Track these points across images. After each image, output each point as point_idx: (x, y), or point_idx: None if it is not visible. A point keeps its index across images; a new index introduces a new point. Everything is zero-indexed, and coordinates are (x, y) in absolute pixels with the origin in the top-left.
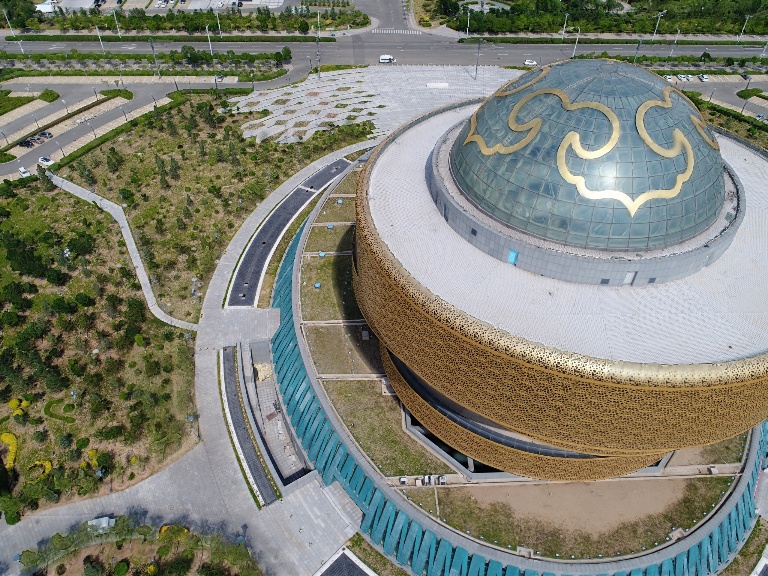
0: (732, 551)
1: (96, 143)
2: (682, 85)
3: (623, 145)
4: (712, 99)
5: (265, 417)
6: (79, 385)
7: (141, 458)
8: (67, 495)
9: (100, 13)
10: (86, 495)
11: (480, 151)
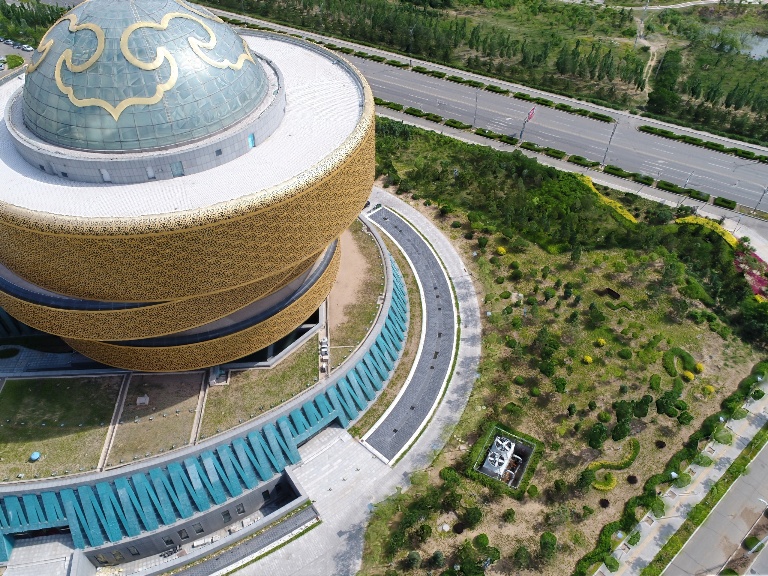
0: None
1: None
2: None
3: (210, 28)
4: None
5: None
6: None
7: None
8: None
9: None
10: None
11: (147, 105)
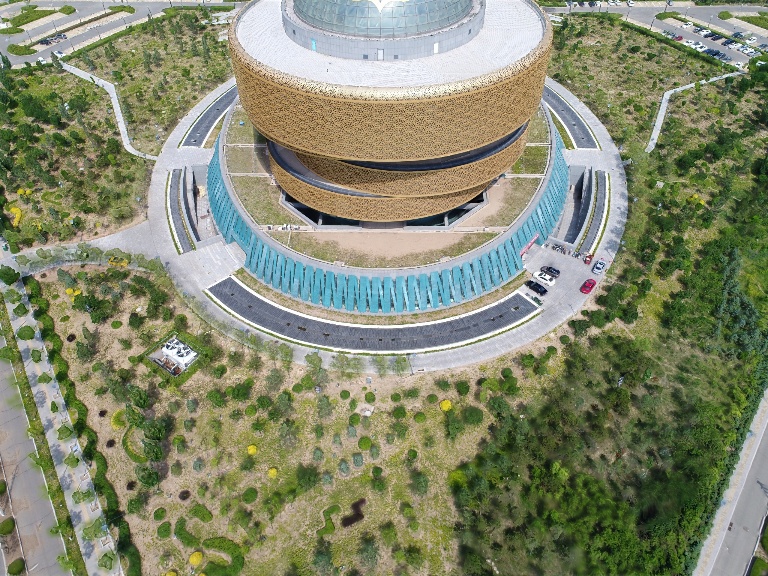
0: (496, 285)
1: (100, 42)
2: (609, 9)
3: None
4: (631, 20)
5: (199, 217)
6: (67, 186)
7: (104, 225)
8: (52, 241)
9: None
10: (64, 241)
11: None
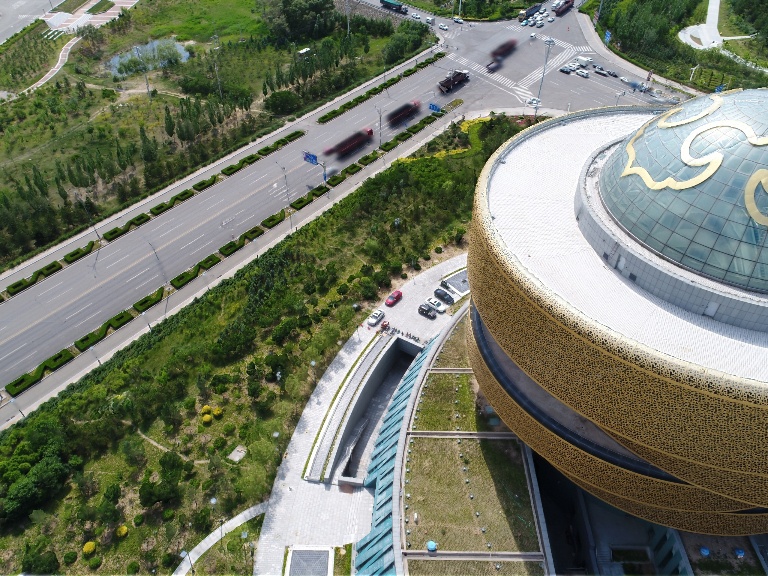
0: None
1: None
2: None
3: None
4: None
5: None
6: None
7: None
8: None
9: None
10: None
11: None
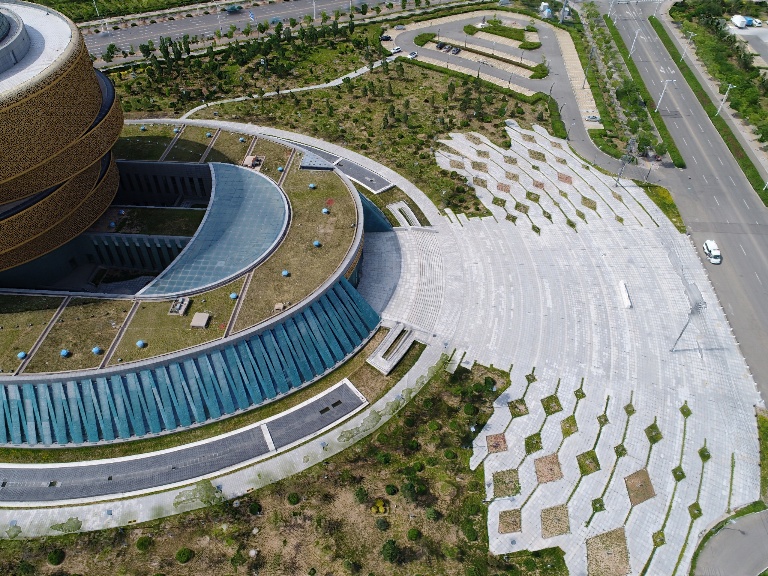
0: None
1: (438, 68)
2: None
3: None
4: None
5: None
6: None
7: None
8: None
9: (734, 42)
10: None
11: None
